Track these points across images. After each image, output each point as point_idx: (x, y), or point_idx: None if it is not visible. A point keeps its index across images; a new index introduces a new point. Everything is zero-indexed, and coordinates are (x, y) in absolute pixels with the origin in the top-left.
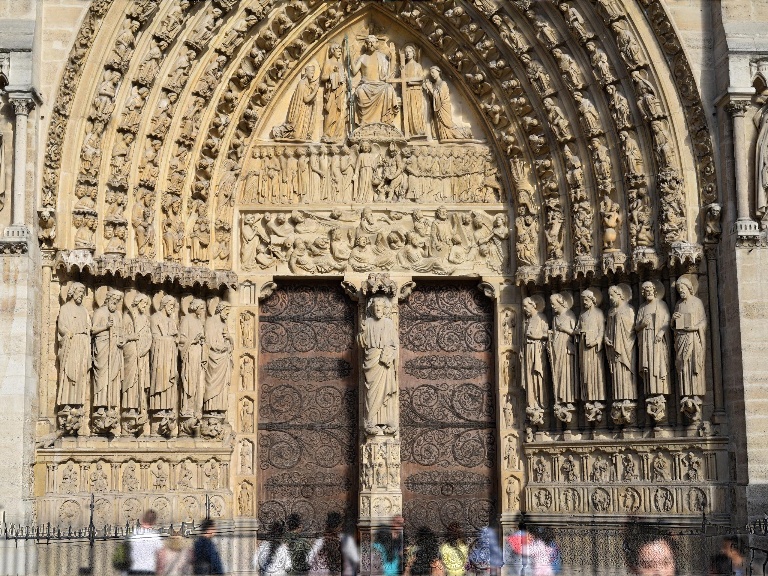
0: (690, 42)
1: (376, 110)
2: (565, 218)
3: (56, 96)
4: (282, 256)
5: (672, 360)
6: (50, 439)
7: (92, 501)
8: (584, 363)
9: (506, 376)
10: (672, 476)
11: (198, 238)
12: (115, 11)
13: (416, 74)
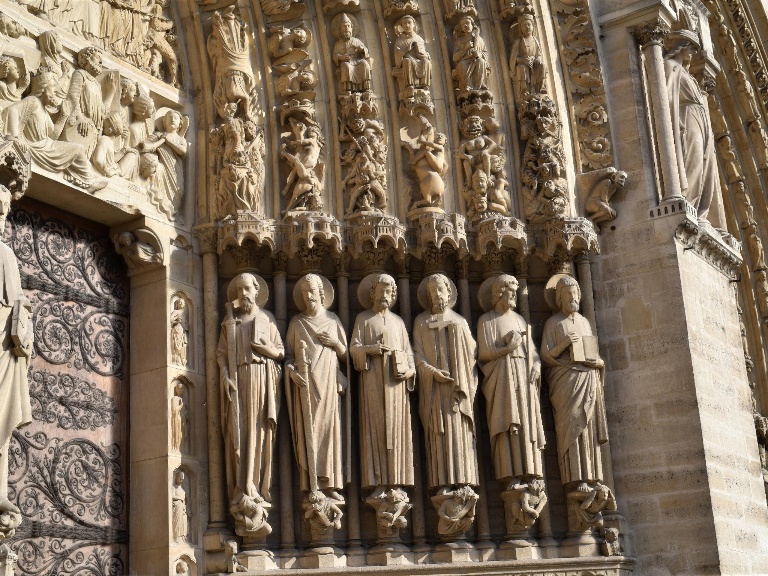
0: None
1: None
2: (325, 142)
3: None
4: None
5: None
6: None
7: None
8: (388, 409)
9: (177, 429)
10: None
11: None
12: None
13: None
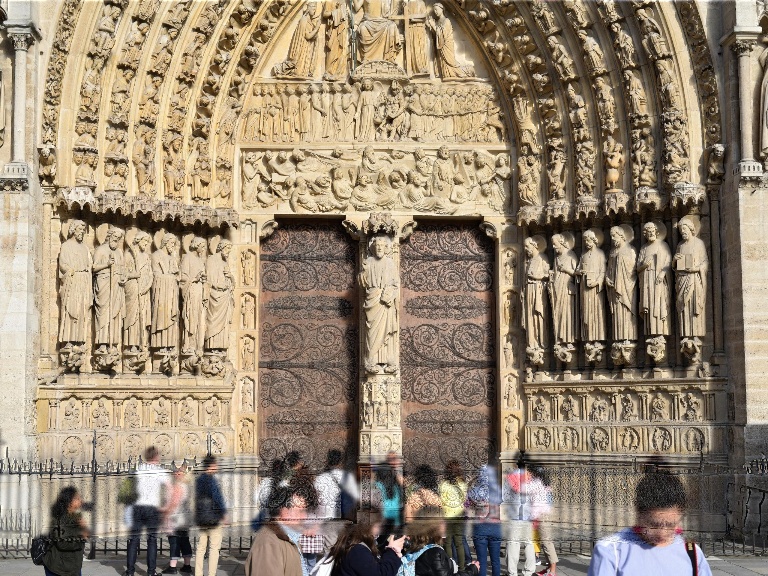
0: None
1: (378, 47)
2: (568, 158)
3: (55, 31)
4: (283, 195)
5: (673, 301)
6: (52, 376)
7: (94, 437)
8: (585, 303)
9: (507, 316)
10: (671, 416)
11: (199, 176)
12: None
13: (419, 11)
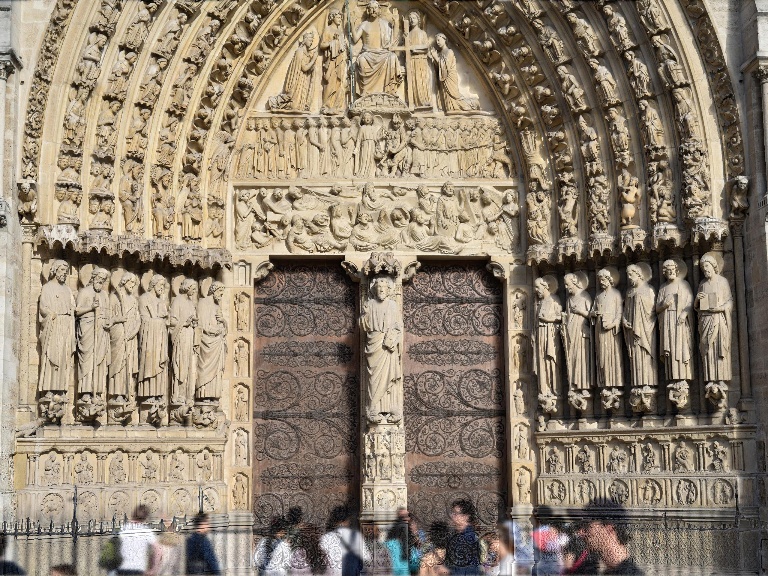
0: (715, 4)
1: (378, 80)
2: (580, 193)
3: (37, 60)
4: (279, 234)
5: (695, 343)
6: (31, 428)
7: (75, 494)
8: (601, 347)
9: (516, 361)
10: (695, 467)
11: (190, 214)
12: None
13: (421, 42)
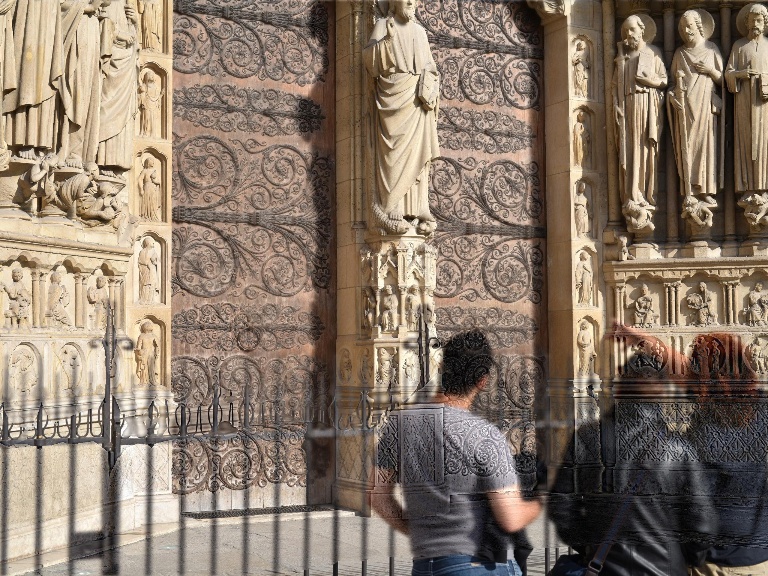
0: None
1: None
2: None
3: None
4: None
5: None
6: None
7: (108, 328)
8: (754, 126)
9: (579, 149)
10: None
11: None
12: None
13: None
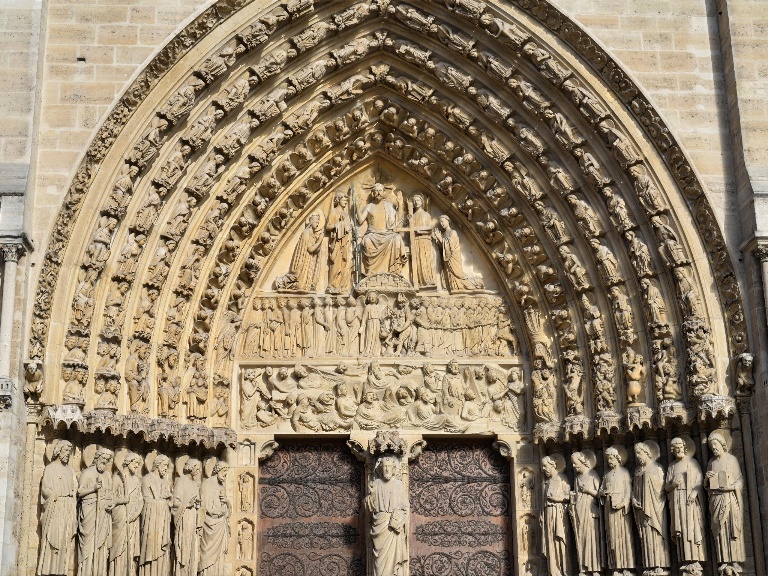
0: (712, 186)
1: (383, 260)
2: (585, 371)
3: (48, 242)
4: (284, 413)
5: (707, 523)
6: None
7: None
8: (610, 527)
9: (525, 542)
10: None
11: (195, 393)
12: (113, 156)
13: (425, 223)
